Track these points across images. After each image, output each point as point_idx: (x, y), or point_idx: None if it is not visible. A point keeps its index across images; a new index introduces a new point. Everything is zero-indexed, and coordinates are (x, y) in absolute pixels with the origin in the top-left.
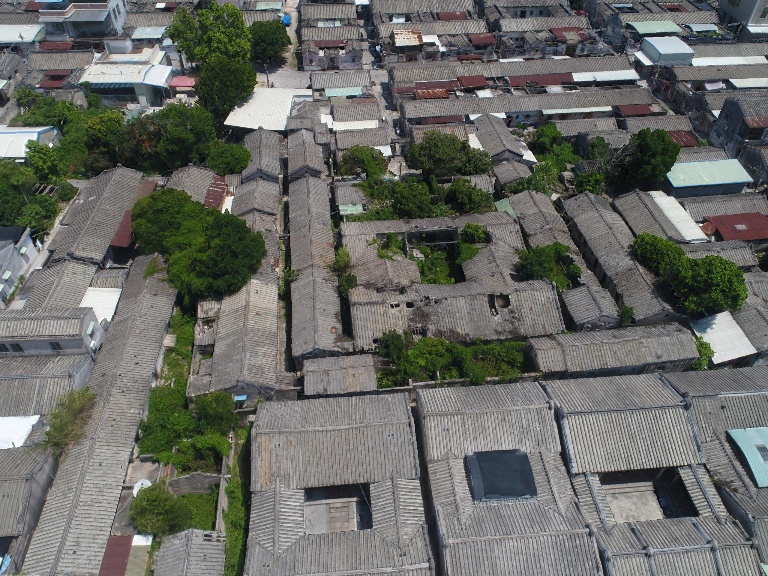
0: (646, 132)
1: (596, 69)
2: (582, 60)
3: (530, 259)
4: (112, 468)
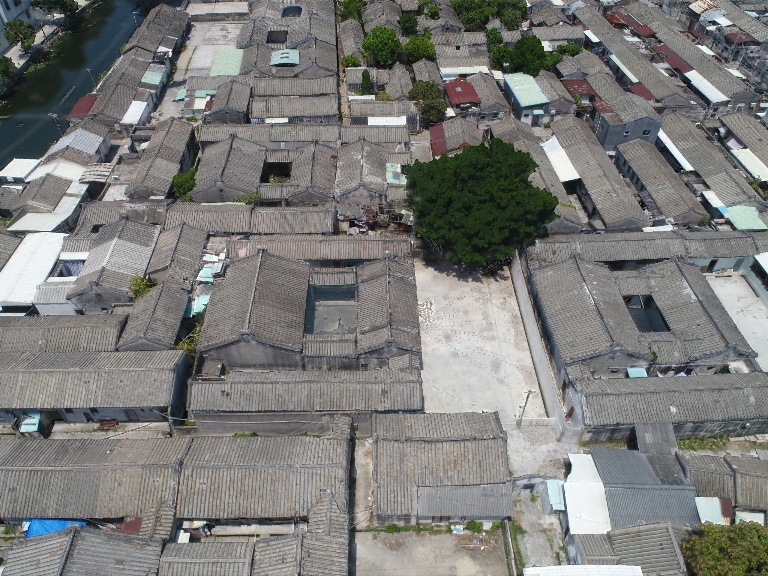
0: None
1: (710, 79)
2: (717, 69)
3: None
4: None
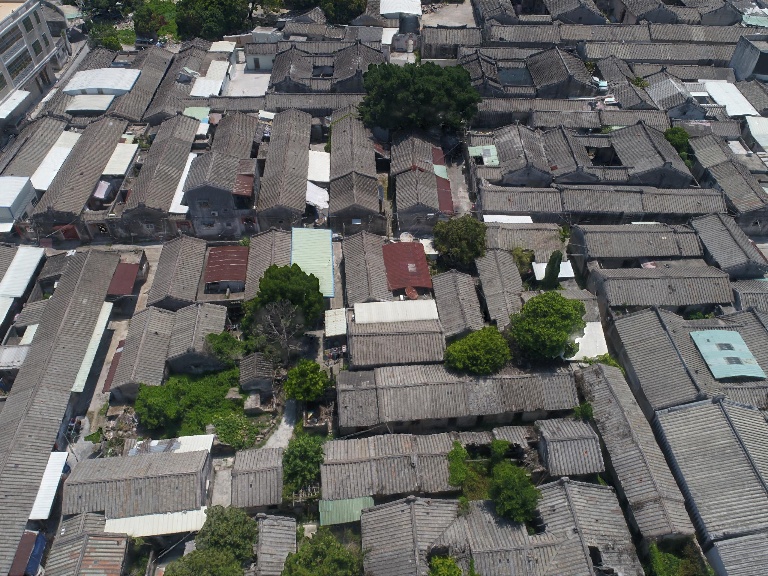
0: (277, 284)
1: None
2: None
3: (530, 498)
4: None
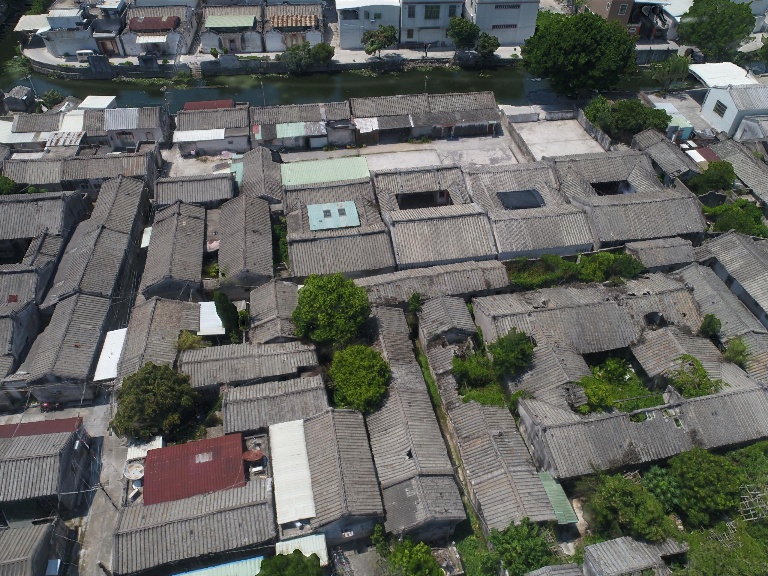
0: None
1: None
2: None
3: None
4: (766, 191)
